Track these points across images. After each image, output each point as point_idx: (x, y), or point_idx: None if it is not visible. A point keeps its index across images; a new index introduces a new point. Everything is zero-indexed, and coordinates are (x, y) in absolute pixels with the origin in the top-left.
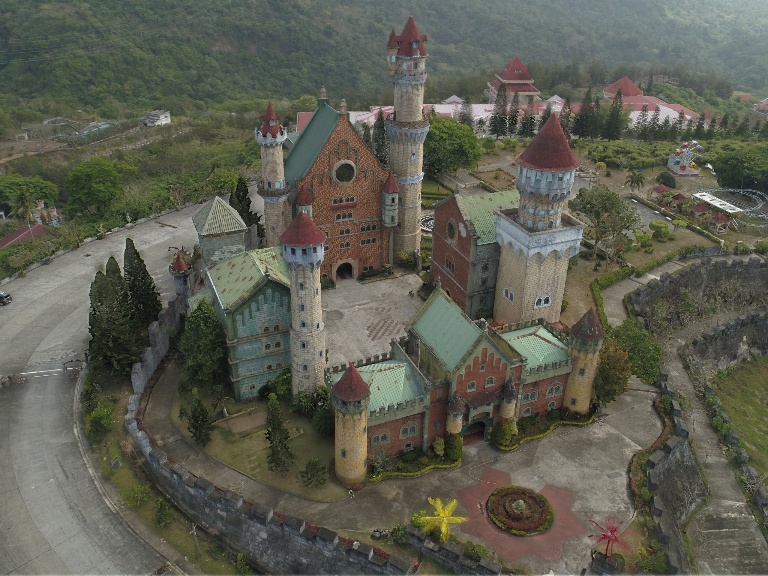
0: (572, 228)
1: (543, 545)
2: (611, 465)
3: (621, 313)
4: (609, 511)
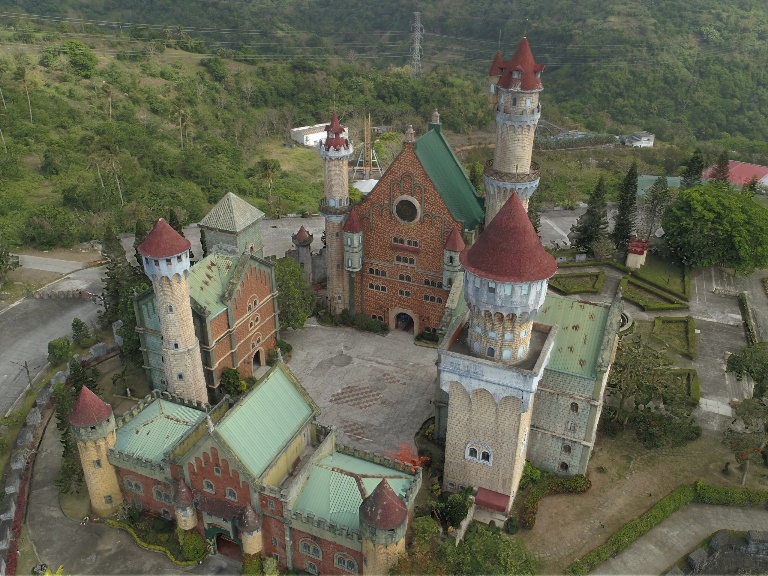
0: (508, 369)
1: None
2: None
3: (680, 549)
4: None
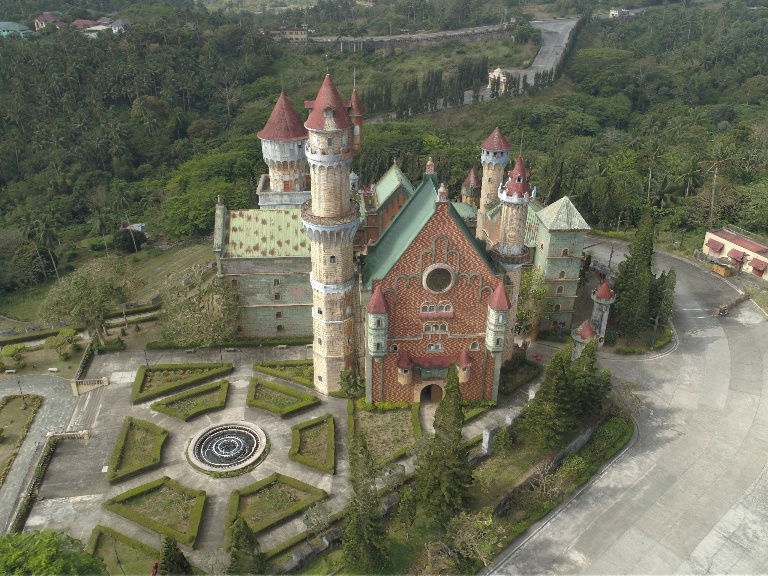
0: None
1: None
2: None
3: None
4: None
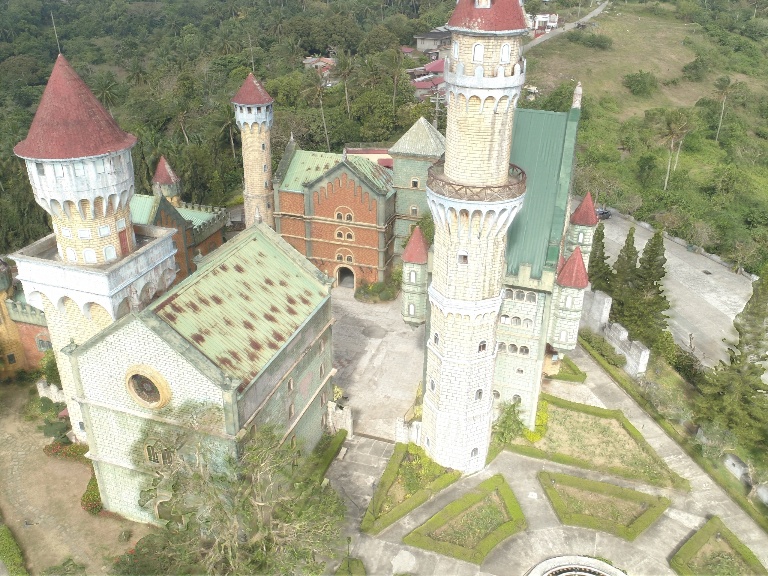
0: (33, 244)
1: None
2: None
3: None
4: None
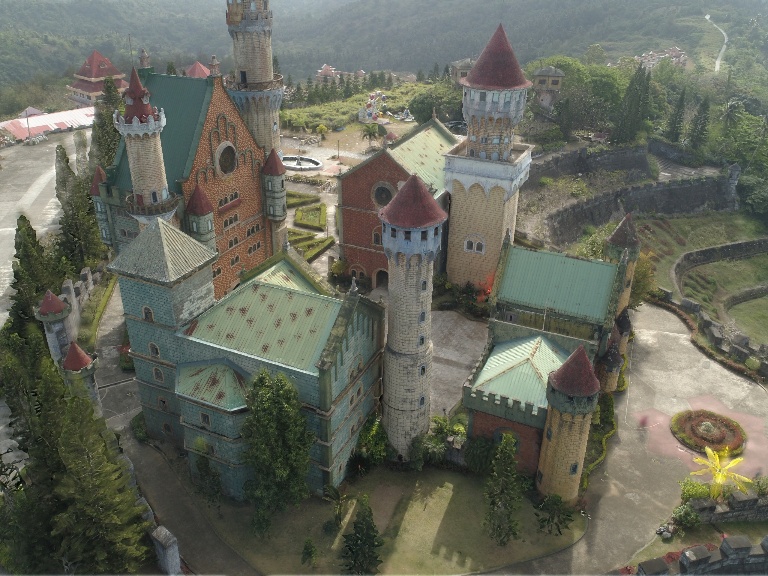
0: None
1: (761, 450)
2: (693, 359)
3: None
4: (747, 394)
